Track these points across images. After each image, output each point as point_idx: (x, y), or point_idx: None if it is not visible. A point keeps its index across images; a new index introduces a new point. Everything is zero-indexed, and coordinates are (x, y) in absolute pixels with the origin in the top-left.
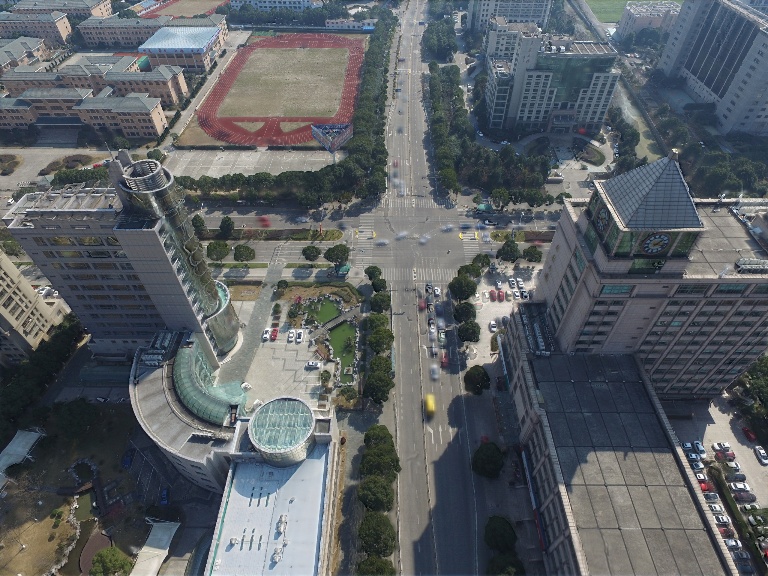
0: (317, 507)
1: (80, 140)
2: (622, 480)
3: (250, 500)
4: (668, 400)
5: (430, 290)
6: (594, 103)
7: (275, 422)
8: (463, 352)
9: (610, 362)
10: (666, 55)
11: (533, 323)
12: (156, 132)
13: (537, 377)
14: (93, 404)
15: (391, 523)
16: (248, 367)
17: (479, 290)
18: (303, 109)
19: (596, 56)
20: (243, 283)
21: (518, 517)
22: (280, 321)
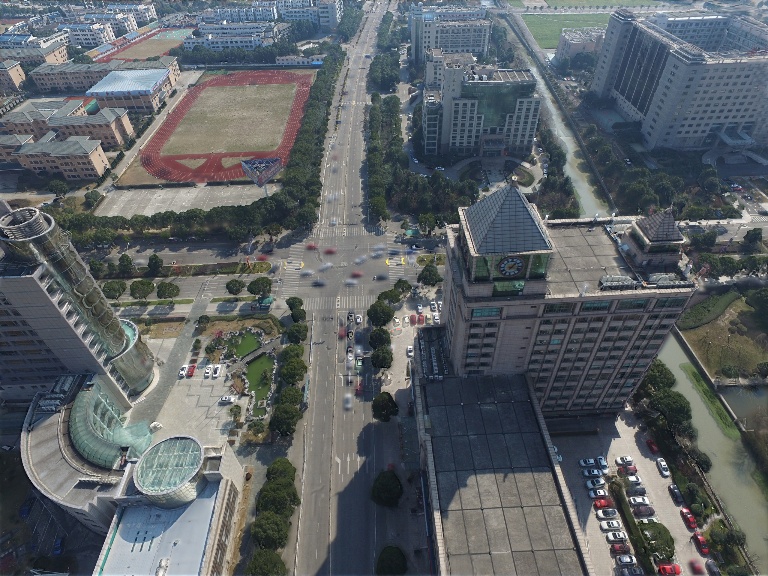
0: (201, 548)
1: (20, 185)
2: (499, 503)
3: (133, 545)
4: (571, 417)
5: (351, 318)
6: (521, 127)
7: (163, 463)
8: (379, 379)
9: (502, 383)
10: (597, 77)
11: (431, 347)
12: (96, 173)
13: (428, 402)
14: None
15: (288, 560)
16: (161, 406)
17: (400, 315)
18: (246, 144)
19: (517, 83)
20: (166, 320)
21: (417, 545)
22: (199, 357)
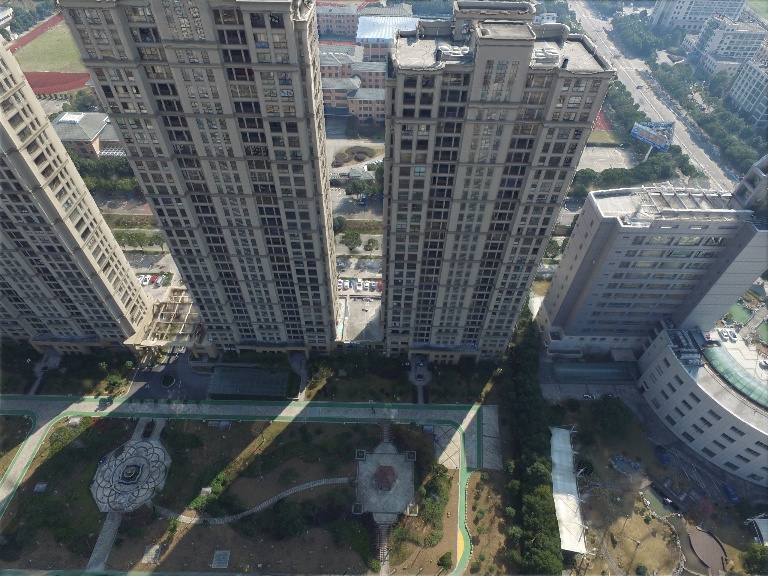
0: None
1: (351, 131)
2: None
3: None
4: None
5: None
6: None
7: None
8: None
9: None
10: None
11: None
12: None
13: None
14: (590, 401)
15: None
16: None
17: None
18: None
19: None
20: None
21: None
22: None
